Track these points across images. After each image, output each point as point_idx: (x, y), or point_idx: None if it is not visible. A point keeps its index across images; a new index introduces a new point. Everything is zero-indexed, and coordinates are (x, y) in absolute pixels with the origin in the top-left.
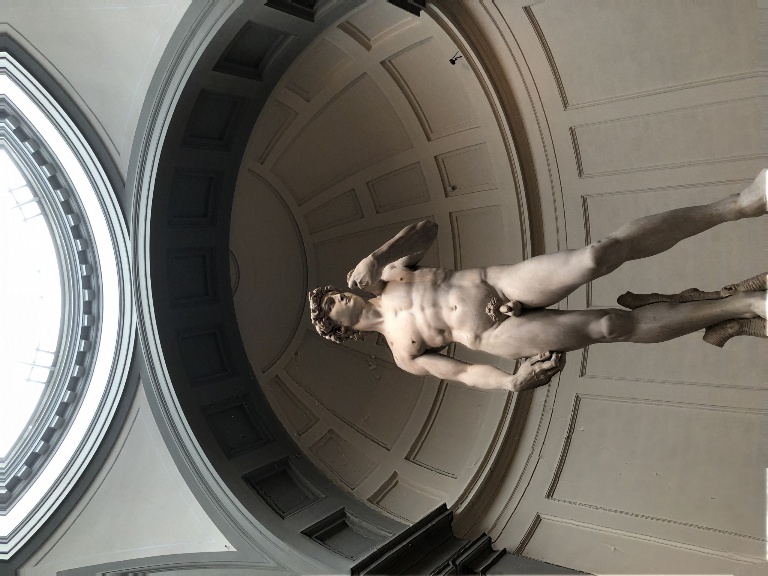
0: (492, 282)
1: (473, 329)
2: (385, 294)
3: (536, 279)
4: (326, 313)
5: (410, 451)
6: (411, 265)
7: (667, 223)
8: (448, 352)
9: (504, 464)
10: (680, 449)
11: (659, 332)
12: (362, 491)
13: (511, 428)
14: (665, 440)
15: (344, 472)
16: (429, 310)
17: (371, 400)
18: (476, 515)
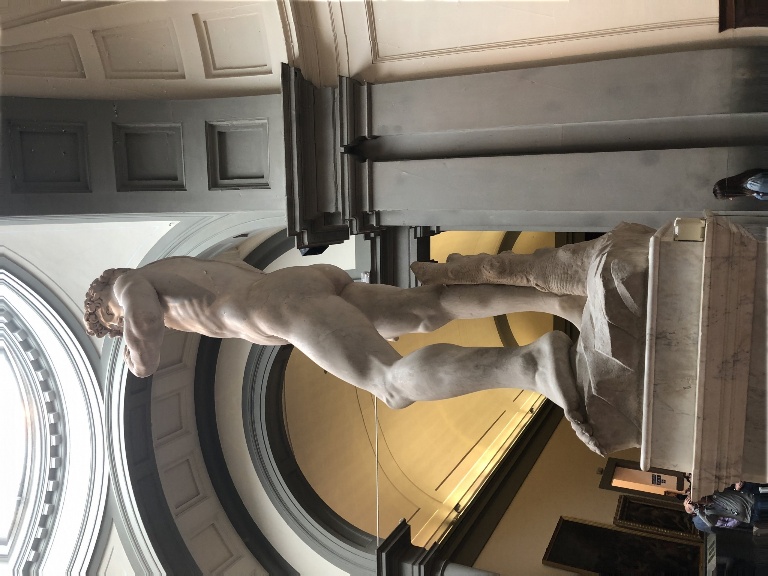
0: None
1: None
2: None
3: None
4: None
5: None
6: None
7: None
8: None
9: None
10: None
11: None
12: (193, 72)
13: None
14: None
15: (156, 62)
16: None
17: None
18: (310, 31)
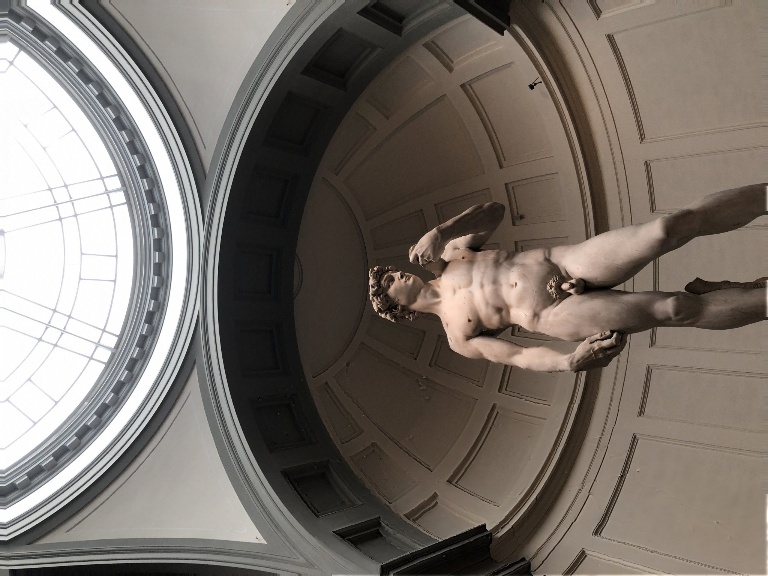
0: (556, 260)
1: (532, 306)
2: (445, 274)
3: (602, 253)
4: (384, 290)
5: (453, 475)
6: (474, 247)
7: (745, 195)
8: (501, 382)
9: (551, 497)
10: (745, 500)
11: (730, 315)
12: (399, 506)
13: (561, 461)
14: (729, 488)
15: (383, 486)
16: (488, 287)
17: (418, 420)
18: (517, 543)
